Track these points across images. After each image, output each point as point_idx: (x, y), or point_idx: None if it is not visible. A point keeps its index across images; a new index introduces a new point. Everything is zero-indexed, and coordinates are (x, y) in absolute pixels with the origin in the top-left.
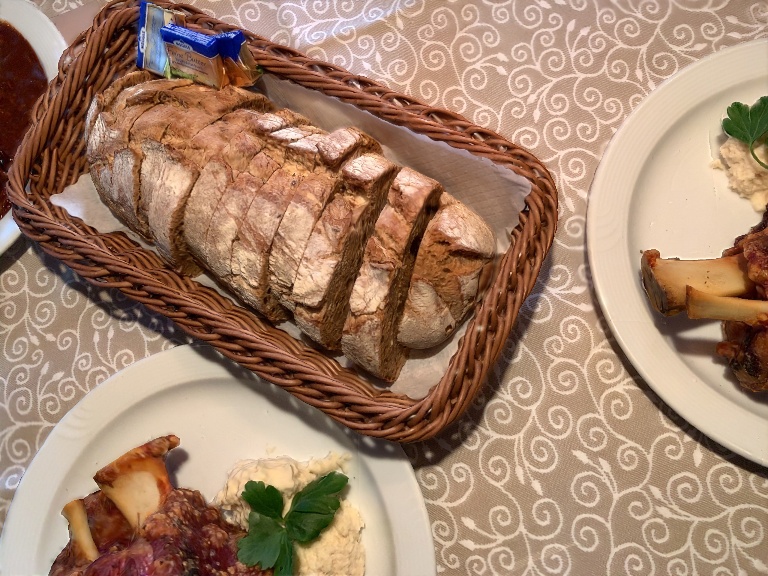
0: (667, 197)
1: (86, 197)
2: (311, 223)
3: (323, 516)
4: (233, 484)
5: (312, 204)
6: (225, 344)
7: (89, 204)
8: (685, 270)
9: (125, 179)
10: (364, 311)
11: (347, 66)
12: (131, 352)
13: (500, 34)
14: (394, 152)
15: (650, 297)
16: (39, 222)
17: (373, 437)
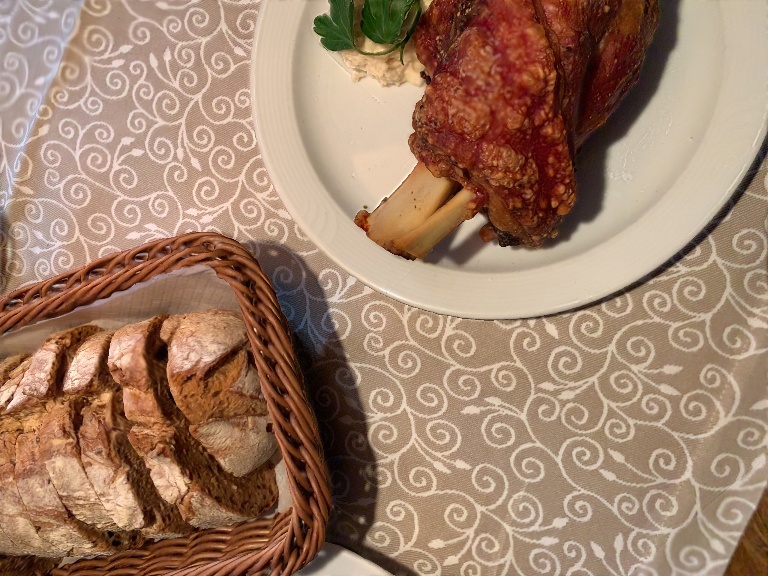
0: (345, 141)
1: None
2: (76, 464)
3: None
4: None
5: (62, 448)
6: None
7: None
8: (394, 209)
9: None
10: (181, 494)
11: (22, 265)
12: None
13: (108, 123)
14: (105, 319)
15: None
16: None
17: None
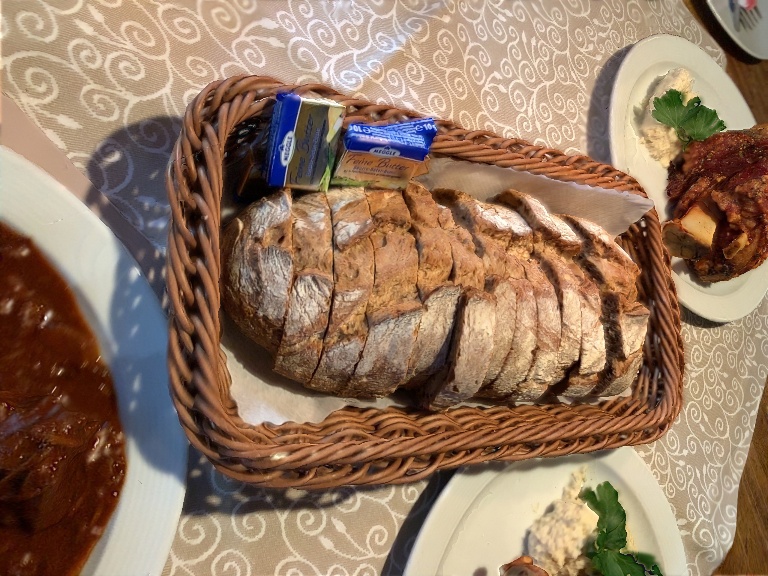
0: None
1: (254, 390)
2: (579, 301)
3: (624, 519)
4: (560, 554)
5: (574, 284)
6: (552, 447)
7: (266, 397)
8: (694, 226)
9: (394, 344)
10: (630, 353)
11: None
12: (379, 526)
13: (488, 52)
14: None
15: (670, 249)
16: (304, 458)
17: None
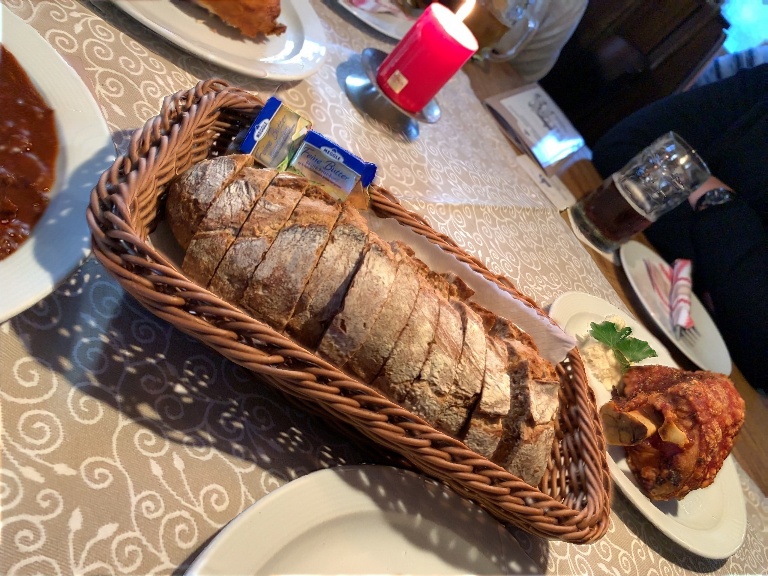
0: None
1: None
2: None
3: None
4: None
5: (481, 324)
6: (438, 451)
7: None
8: None
9: (296, 257)
10: (540, 421)
11: None
12: (222, 488)
13: None
14: None
15: (609, 436)
16: (177, 278)
17: (518, 561)
